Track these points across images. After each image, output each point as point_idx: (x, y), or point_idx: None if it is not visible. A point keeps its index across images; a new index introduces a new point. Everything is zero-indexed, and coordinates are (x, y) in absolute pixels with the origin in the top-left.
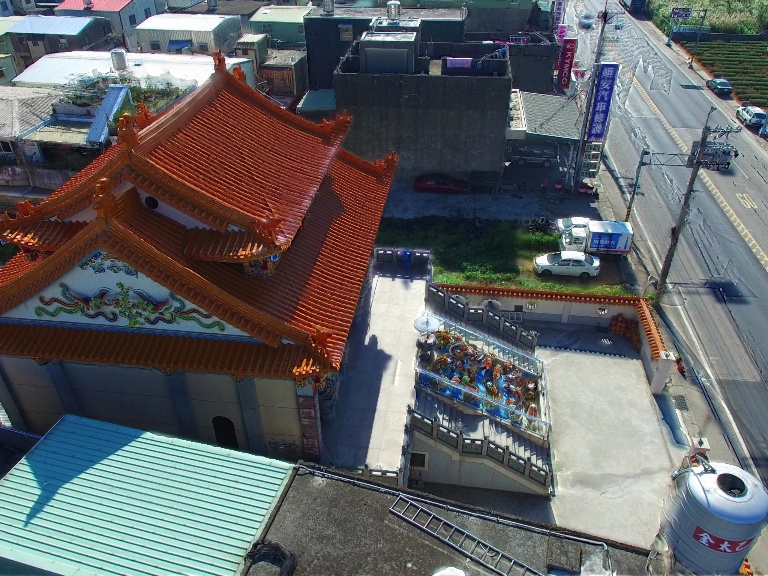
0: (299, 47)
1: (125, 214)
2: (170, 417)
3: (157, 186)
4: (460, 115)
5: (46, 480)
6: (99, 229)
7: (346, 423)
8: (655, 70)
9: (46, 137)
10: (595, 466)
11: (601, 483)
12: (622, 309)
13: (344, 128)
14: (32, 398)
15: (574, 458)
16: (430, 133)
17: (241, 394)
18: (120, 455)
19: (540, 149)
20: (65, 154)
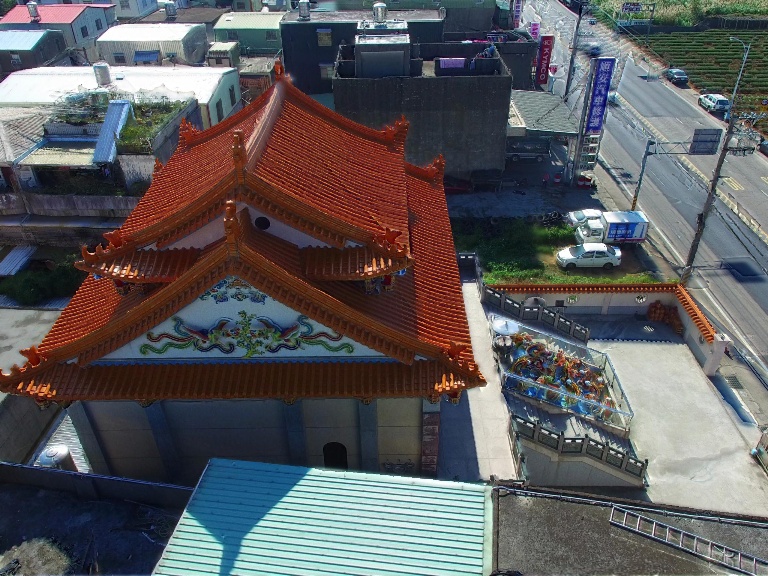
0: (270, 54)
1: (244, 237)
2: (277, 448)
3: (273, 205)
4: (461, 115)
5: (222, 533)
6: (227, 255)
7: (446, 435)
8: (651, 62)
9: (45, 160)
10: (677, 452)
11: (688, 468)
12: (660, 296)
13: (404, 134)
14: (121, 444)
15: (655, 446)
16: (431, 135)
17: (362, 417)
18: (293, 496)
19: (532, 145)
20: (64, 177)
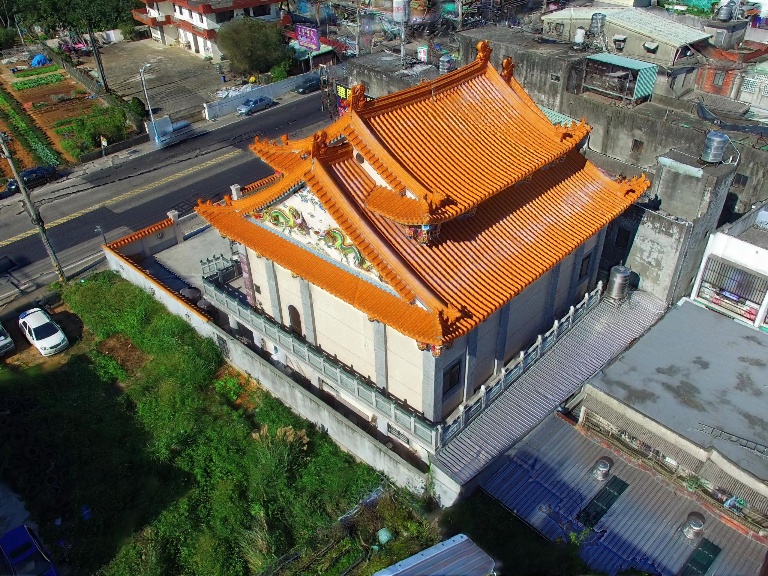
0: None
1: None
2: None
3: None
4: None
5: None
6: None
7: None
8: None
9: None
10: None
11: None
12: None
13: None
14: None
15: None
16: None
17: None
18: None
19: None
20: None
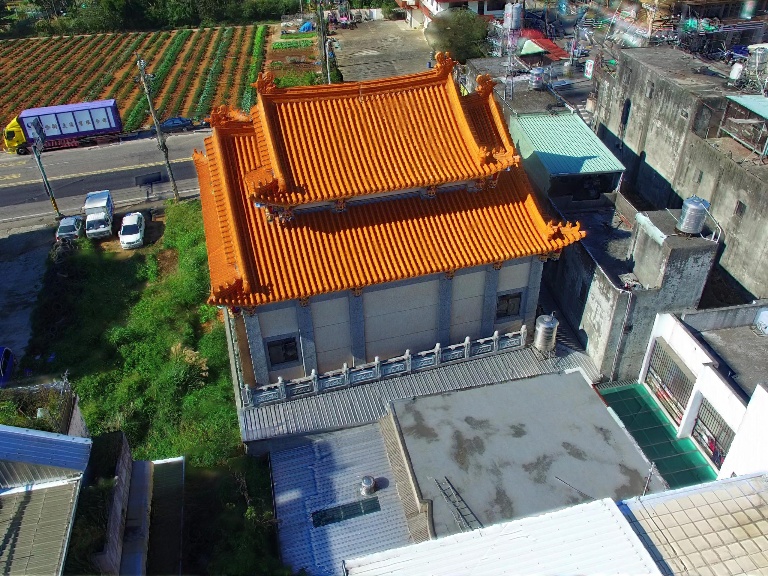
0: None
1: None
2: None
3: None
4: None
5: None
6: None
7: None
8: None
9: (45, 574)
10: None
11: None
12: None
13: None
14: None
15: None
16: None
17: None
18: None
19: None
20: None
